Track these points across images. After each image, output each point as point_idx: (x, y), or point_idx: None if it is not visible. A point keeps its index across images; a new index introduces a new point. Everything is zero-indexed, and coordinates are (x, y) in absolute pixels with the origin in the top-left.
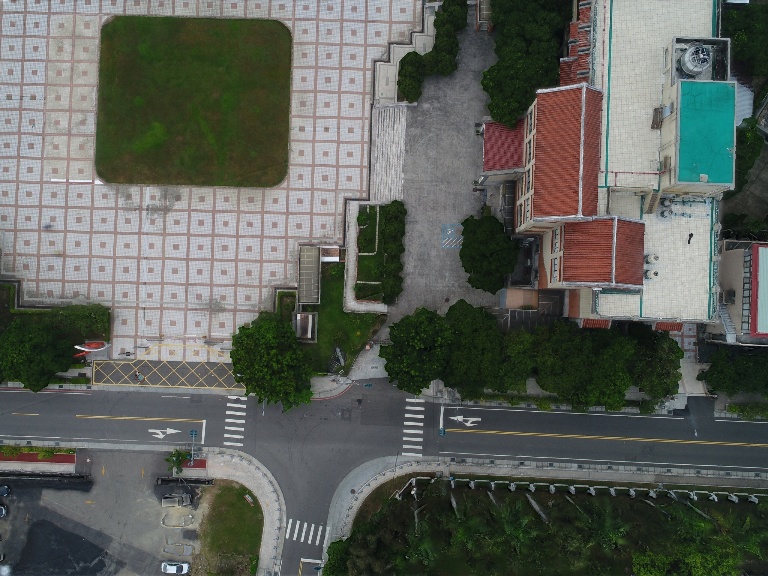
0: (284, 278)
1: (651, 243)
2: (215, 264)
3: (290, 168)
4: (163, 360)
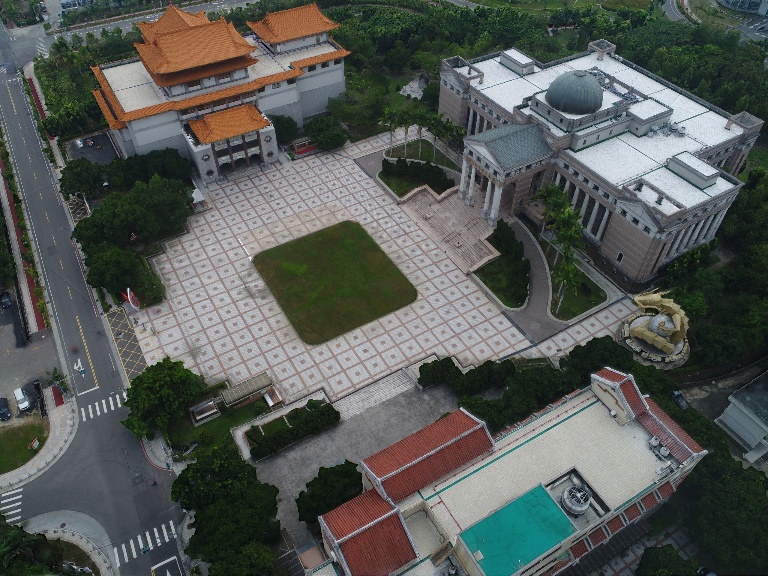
0: (238, 381)
1: None
2: (227, 337)
3: (323, 345)
4: (139, 343)
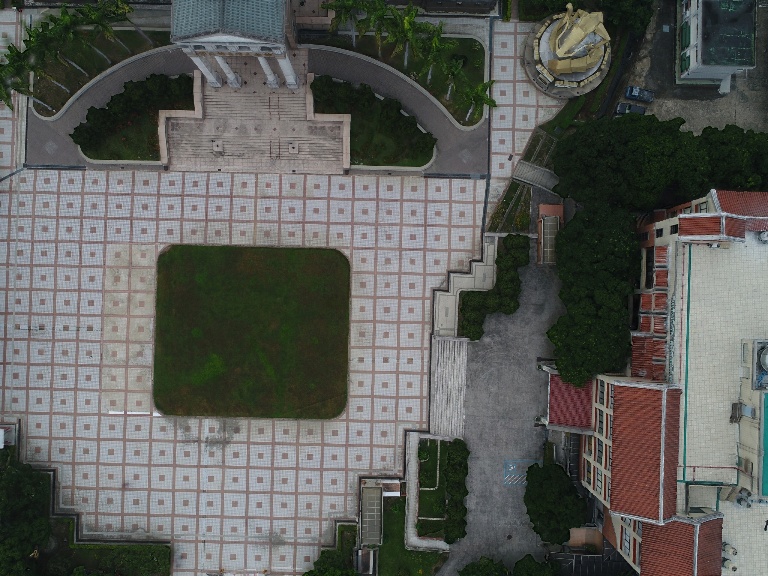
0: (344, 511)
1: (727, 530)
2: (275, 497)
3: (349, 399)
4: None
